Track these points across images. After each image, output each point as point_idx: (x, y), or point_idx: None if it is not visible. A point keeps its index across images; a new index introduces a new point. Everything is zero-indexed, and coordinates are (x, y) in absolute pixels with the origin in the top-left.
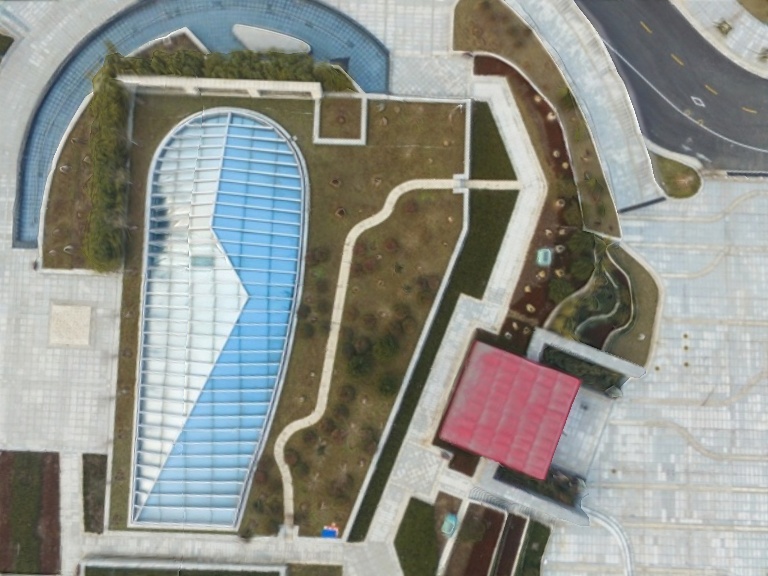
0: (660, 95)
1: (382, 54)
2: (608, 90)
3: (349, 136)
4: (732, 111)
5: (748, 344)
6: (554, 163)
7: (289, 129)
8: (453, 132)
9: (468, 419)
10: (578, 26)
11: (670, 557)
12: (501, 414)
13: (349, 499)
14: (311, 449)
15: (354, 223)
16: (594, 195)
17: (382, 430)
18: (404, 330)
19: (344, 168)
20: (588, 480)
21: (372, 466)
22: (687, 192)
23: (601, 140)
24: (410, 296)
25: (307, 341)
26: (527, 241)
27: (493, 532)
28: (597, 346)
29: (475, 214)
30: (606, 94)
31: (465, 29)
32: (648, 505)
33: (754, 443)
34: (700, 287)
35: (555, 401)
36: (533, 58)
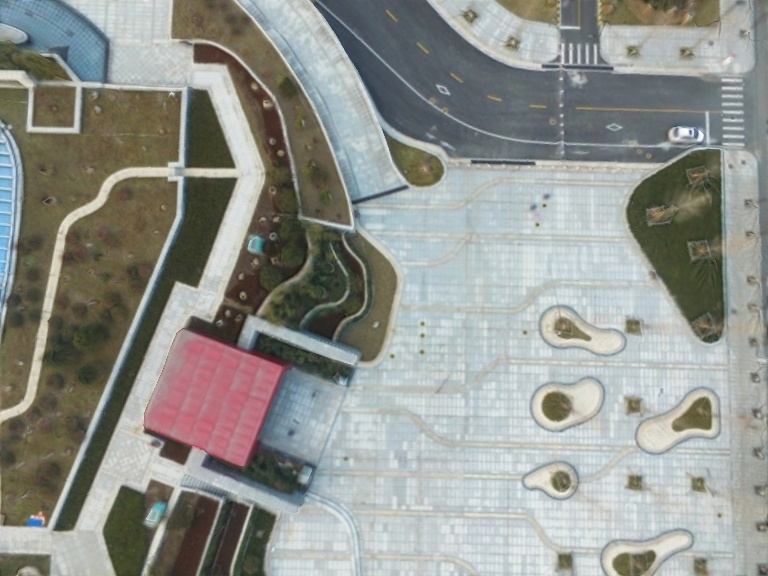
0: (405, 83)
1: (102, 43)
2: (341, 78)
3: (62, 125)
4: (477, 99)
5: (485, 331)
6: (270, 151)
7: (4, 118)
8: (169, 120)
9: (170, 407)
10: (305, 14)
11: (399, 544)
12: (203, 401)
13: (56, 488)
14: (19, 438)
15: (68, 212)
16: (316, 183)
17: (90, 418)
18: (113, 318)
19: (59, 157)
20: (319, 468)
21: (80, 455)
22: (428, 180)
23: (338, 128)
24: (120, 284)
25: (18, 330)
26: (244, 229)
27: (205, 520)
28: (328, 334)
29: (191, 202)
30: (340, 82)
31: (185, 17)
32: (379, 492)
33: (487, 430)
34: (440, 275)
35: (257, 388)
36: (253, 46)
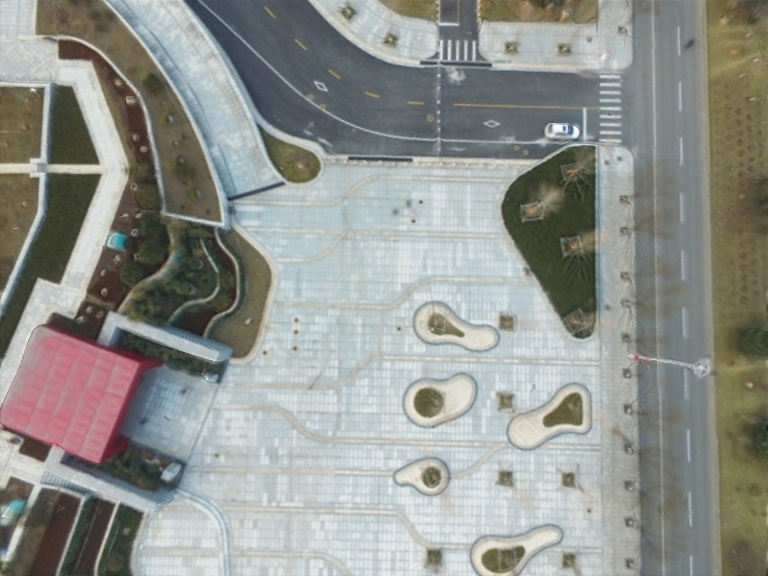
0: (283, 80)
1: None
2: (213, 75)
3: None
4: (354, 96)
5: (359, 327)
6: (134, 147)
7: None
8: (31, 116)
9: (25, 403)
10: (174, 10)
11: (269, 540)
12: (59, 398)
13: None
14: None
15: None
16: (182, 179)
17: None
18: None
19: None
20: (189, 465)
21: None
22: (304, 176)
23: (212, 125)
24: None
25: None
26: (108, 225)
27: (66, 517)
28: (198, 330)
29: (53, 198)
30: (213, 79)
31: (49, 13)
32: (250, 489)
33: (359, 426)
34: (315, 271)
35: (113, 384)
36: (118, 42)
